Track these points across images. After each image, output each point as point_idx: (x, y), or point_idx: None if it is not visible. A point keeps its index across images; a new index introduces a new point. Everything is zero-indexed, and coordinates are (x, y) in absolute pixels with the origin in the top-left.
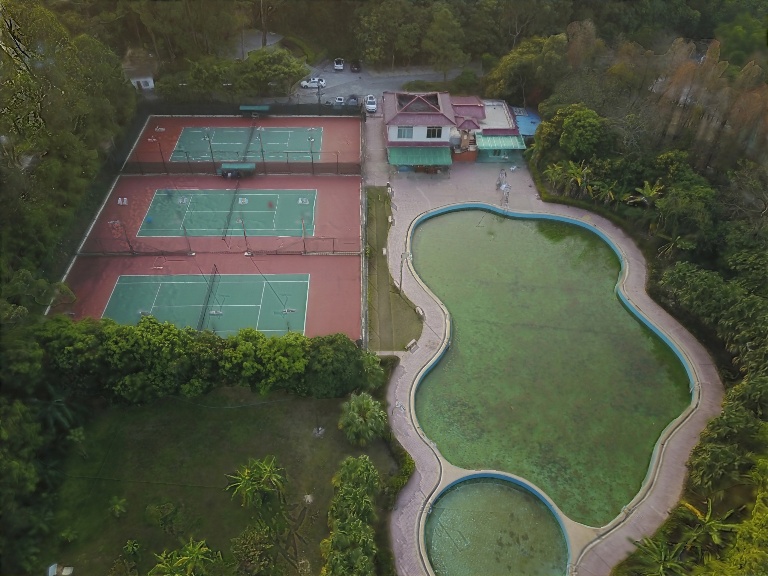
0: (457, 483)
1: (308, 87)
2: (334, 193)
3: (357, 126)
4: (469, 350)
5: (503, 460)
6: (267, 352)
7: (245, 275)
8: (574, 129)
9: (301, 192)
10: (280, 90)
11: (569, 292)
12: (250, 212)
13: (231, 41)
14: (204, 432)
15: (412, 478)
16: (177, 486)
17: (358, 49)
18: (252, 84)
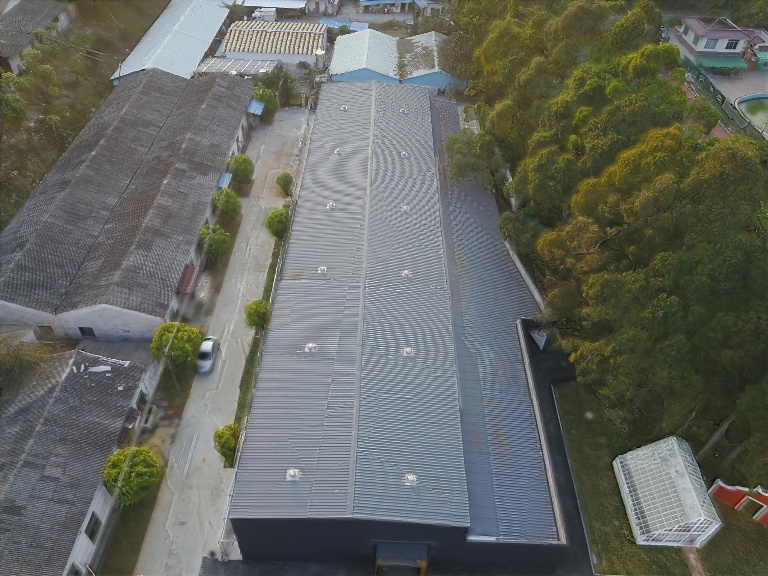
0: None
1: None
2: None
3: None
4: None
5: None
6: None
7: None
8: None
9: None
10: None
11: None
12: None
13: None
14: None
15: None
16: None
17: None
18: None
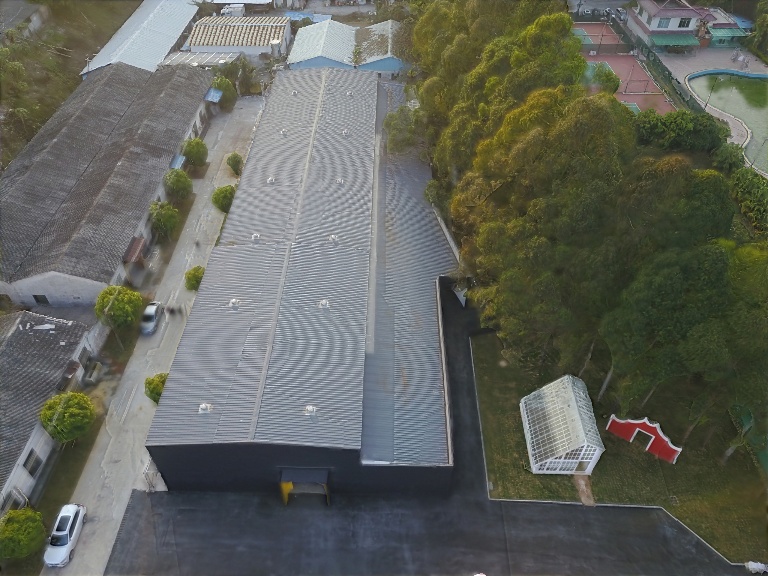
0: None
1: None
2: (622, 63)
3: (607, 28)
4: (763, 140)
5: None
6: (668, 119)
7: None
8: None
9: None
10: None
11: None
12: None
13: None
14: None
15: None
16: None
17: None
18: None
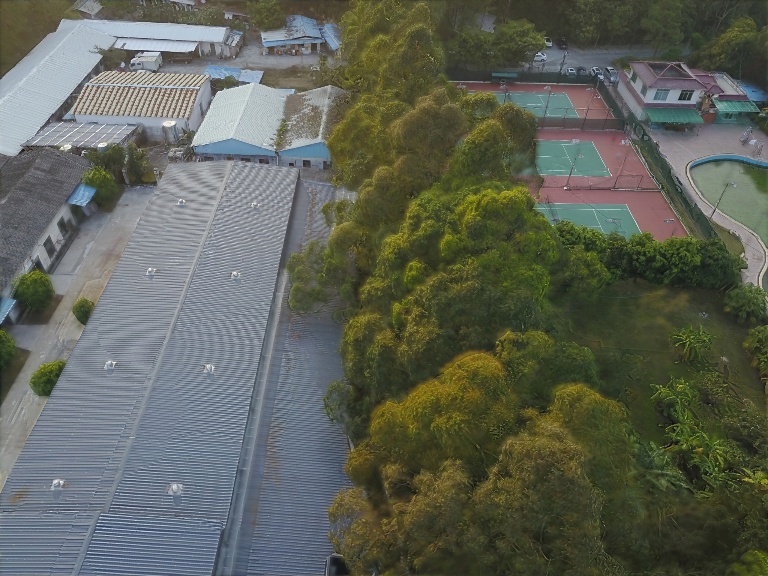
0: None
1: None
2: (610, 144)
3: (594, 92)
4: None
5: None
6: (669, 249)
7: (574, 204)
8: None
9: (580, 143)
10: (528, 60)
11: None
12: (547, 157)
13: (475, 17)
14: (613, 314)
15: None
16: (616, 349)
17: (568, 28)
18: (503, 54)
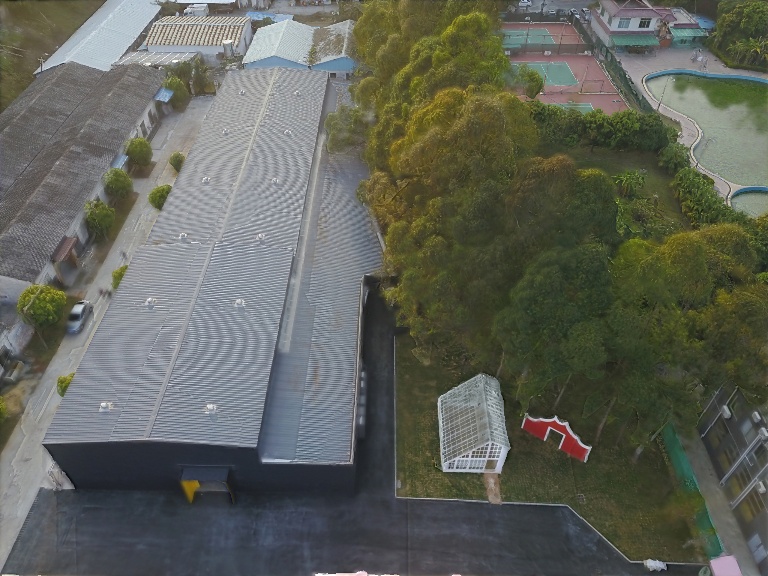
0: (739, 192)
1: (519, 6)
2: (581, 63)
3: (571, 28)
4: None
5: (762, 184)
6: (615, 119)
7: None
8: (754, 14)
9: (556, 63)
10: (514, 2)
11: (767, 114)
12: None
13: None
14: None
15: (713, 188)
16: None
17: None
18: None
